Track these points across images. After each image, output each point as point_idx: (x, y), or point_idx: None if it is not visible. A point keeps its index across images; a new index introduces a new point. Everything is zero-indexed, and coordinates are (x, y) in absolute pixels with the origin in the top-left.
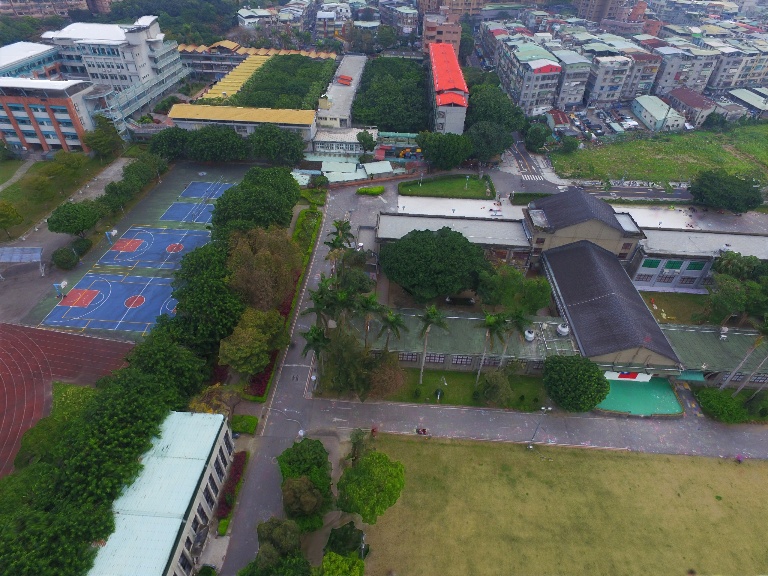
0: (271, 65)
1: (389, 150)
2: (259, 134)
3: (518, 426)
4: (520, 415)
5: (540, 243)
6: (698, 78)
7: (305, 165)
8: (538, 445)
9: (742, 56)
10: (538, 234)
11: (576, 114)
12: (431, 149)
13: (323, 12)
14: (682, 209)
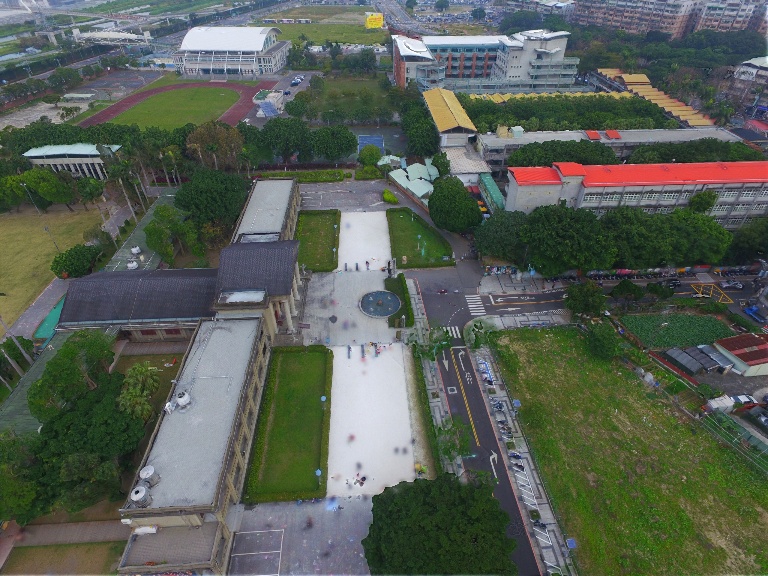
0: (594, 100)
1: None
2: None
3: None
4: None
5: None
6: None
7: (410, 159)
8: None
9: None
10: None
11: None
12: None
13: None
14: None
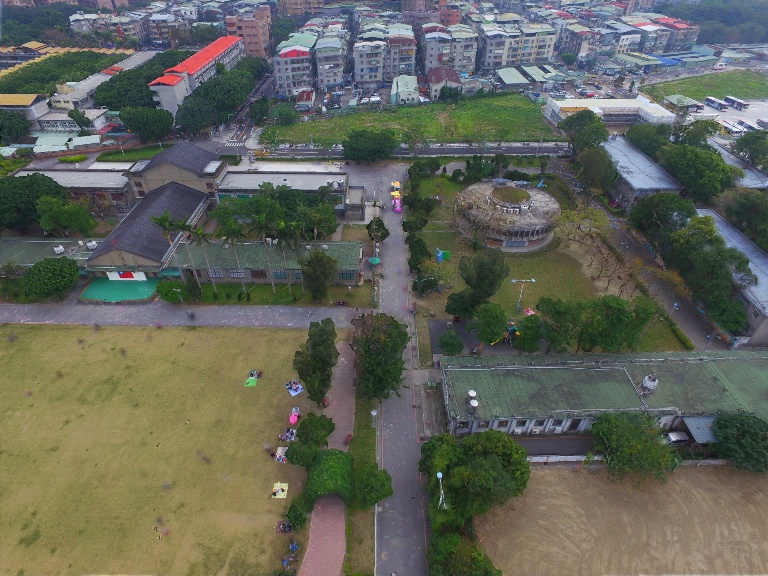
0: (53, 60)
1: (120, 127)
2: None
3: (7, 313)
4: (17, 306)
5: (140, 186)
6: (463, 59)
7: (22, 140)
8: (9, 323)
9: (504, 38)
10: (131, 178)
11: (333, 94)
12: (127, 121)
13: (159, 15)
14: (339, 163)
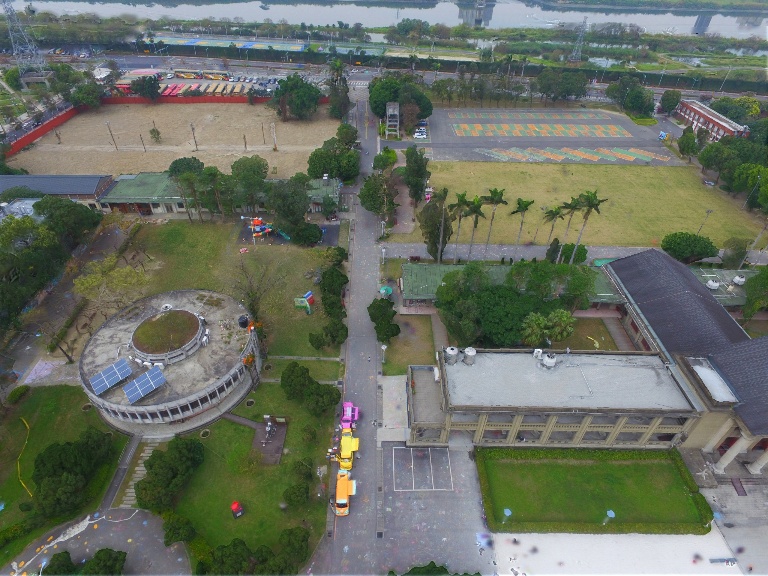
0: None
1: None
2: None
3: None
4: (705, 261)
5: None
6: None
7: None
8: None
9: None
10: None
11: None
12: None
13: None
14: None
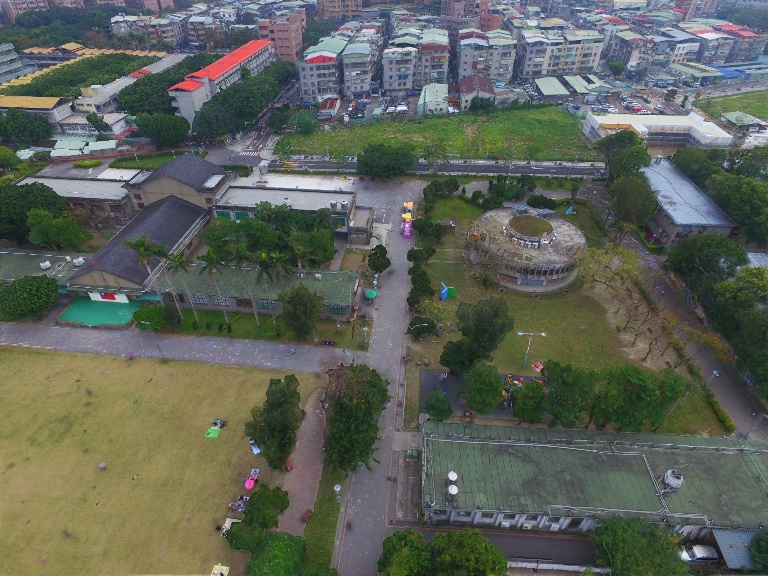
0: (86, 62)
1: None
2: (6, 117)
3: None
4: None
5: (139, 199)
6: (500, 67)
7: (42, 143)
8: None
9: (546, 45)
10: (131, 190)
11: (359, 101)
12: (142, 128)
13: (197, 17)
14: (353, 178)
